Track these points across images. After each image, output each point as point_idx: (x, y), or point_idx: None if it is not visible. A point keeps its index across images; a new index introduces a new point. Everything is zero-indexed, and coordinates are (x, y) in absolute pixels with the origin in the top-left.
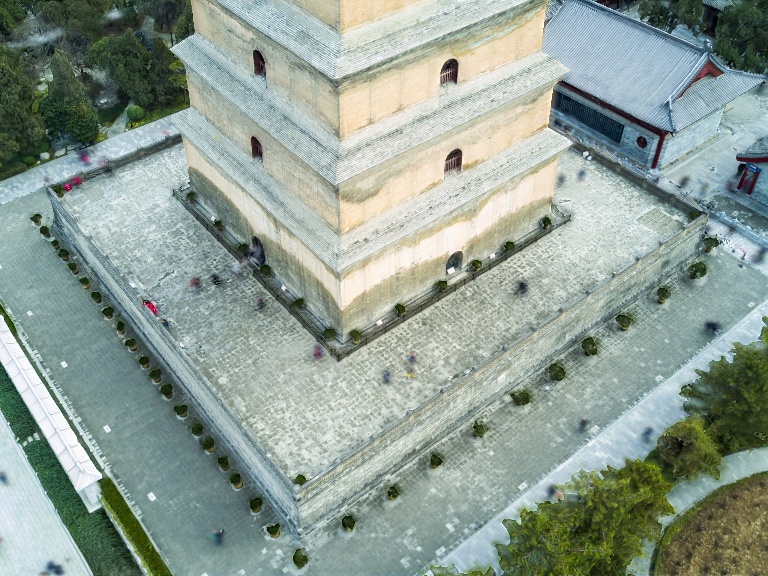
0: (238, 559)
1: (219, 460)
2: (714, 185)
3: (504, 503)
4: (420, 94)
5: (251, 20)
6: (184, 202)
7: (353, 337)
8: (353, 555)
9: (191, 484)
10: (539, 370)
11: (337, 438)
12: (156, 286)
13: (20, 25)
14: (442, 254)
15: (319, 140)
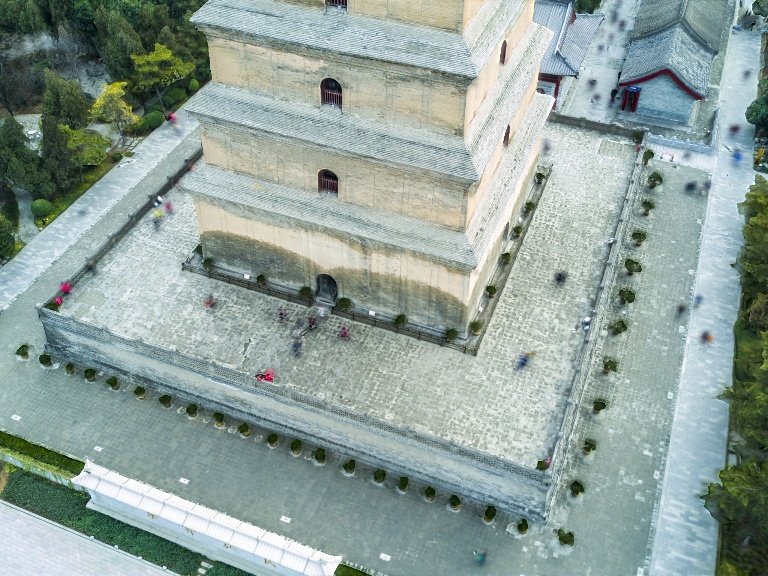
0: (510, 568)
1: (428, 492)
2: (603, 113)
3: (669, 415)
4: (492, 79)
5: (337, 46)
6: (204, 271)
7: (473, 330)
8: (597, 514)
9: (412, 528)
10: (608, 301)
11: (531, 419)
12: (245, 360)
13: None
14: (502, 228)
15: (436, 145)
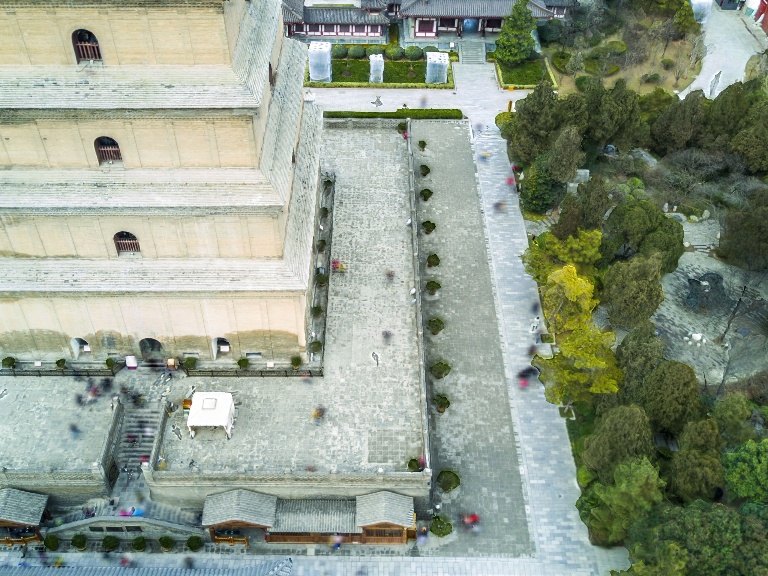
0: None
1: None
2: None
3: None
4: None
5: None
6: None
7: None
8: None
9: None
10: None
11: None
12: None
13: (765, 184)
14: None
15: None
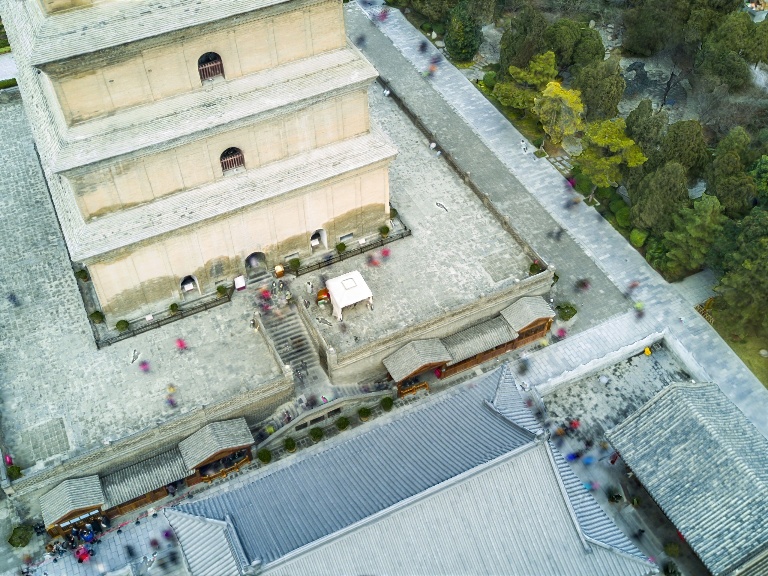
0: None
1: None
2: None
3: None
4: None
5: None
6: None
7: None
8: None
9: None
10: None
11: None
12: None
13: None
14: None
15: None
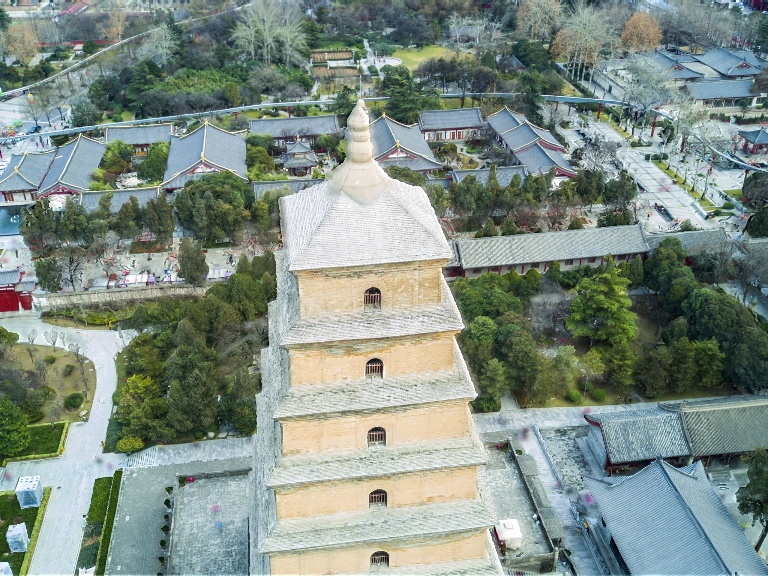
0: None
1: None
2: None
3: None
4: (350, 567)
5: (258, 469)
6: None
7: None
8: None
9: None
10: None
11: None
12: None
13: (256, 319)
14: None
15: (265, 573)
